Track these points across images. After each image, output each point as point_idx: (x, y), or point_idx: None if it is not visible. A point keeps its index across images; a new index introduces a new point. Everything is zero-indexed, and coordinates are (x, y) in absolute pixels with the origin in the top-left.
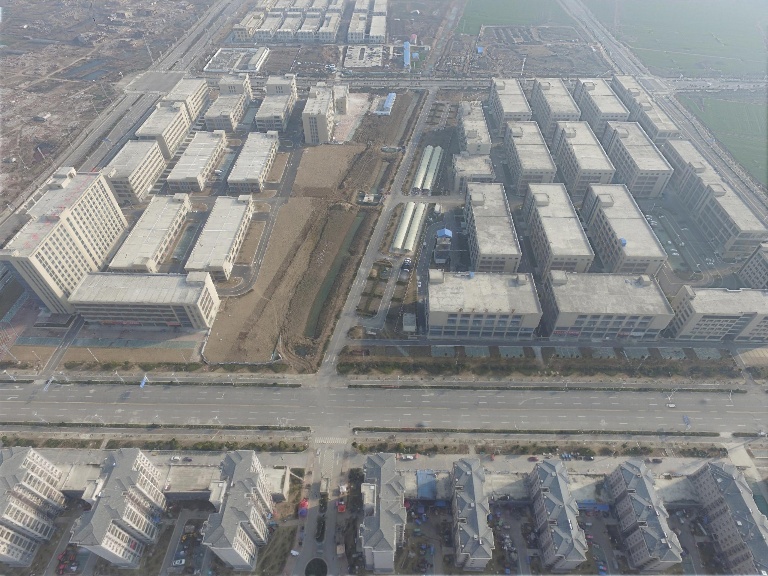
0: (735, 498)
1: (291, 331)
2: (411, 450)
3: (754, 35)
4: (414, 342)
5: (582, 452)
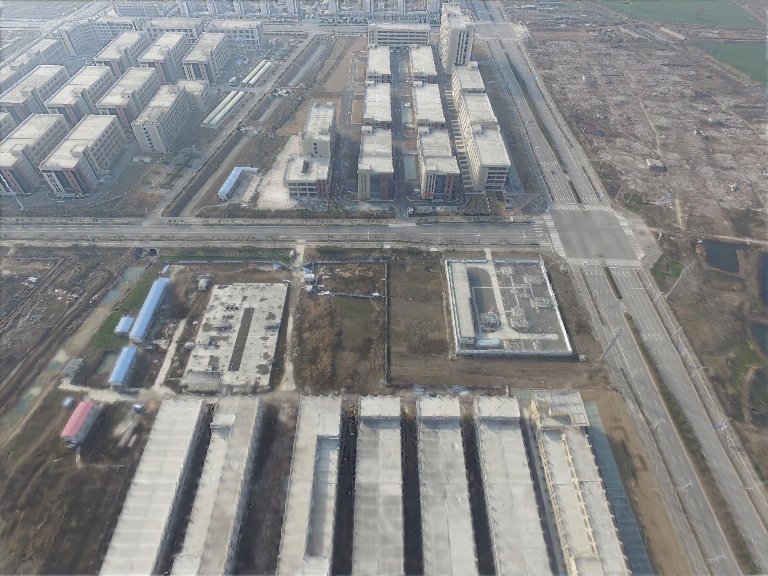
0: None
1: None
2: (282, 21)
3: None
4: None
5: None
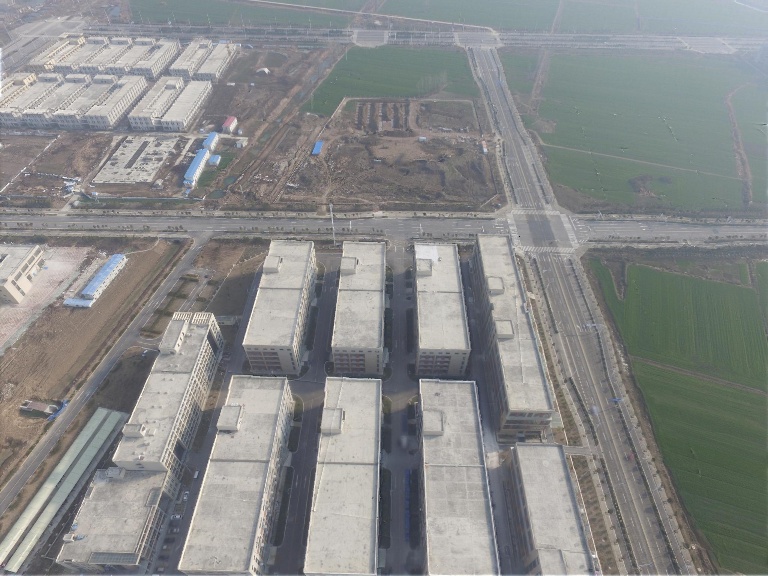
0: None
1: None
2: None
3: (721, 121)
4: None
5: None
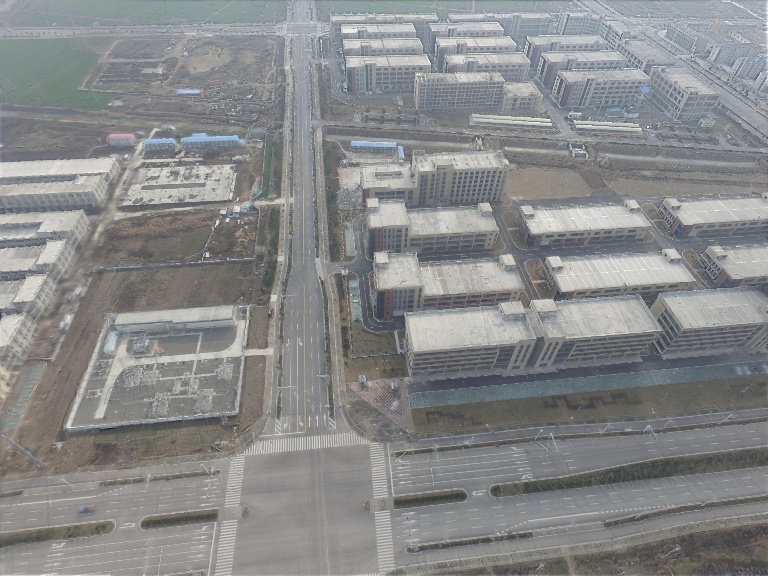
0: (733, 45)
1: (764, 168)
2: None
3: None
4: (716, 123)
5: (727, 83)
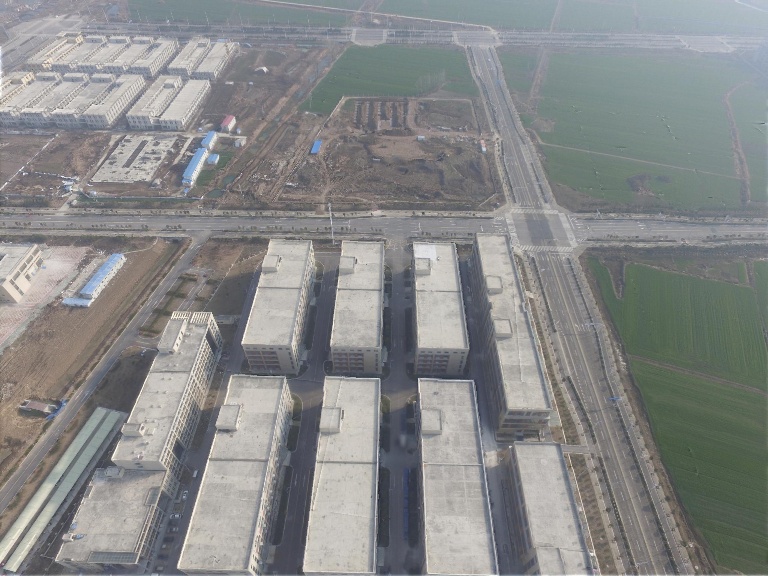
0: None
1: None
2: None
3: (719, 120)
4: None
5: None
